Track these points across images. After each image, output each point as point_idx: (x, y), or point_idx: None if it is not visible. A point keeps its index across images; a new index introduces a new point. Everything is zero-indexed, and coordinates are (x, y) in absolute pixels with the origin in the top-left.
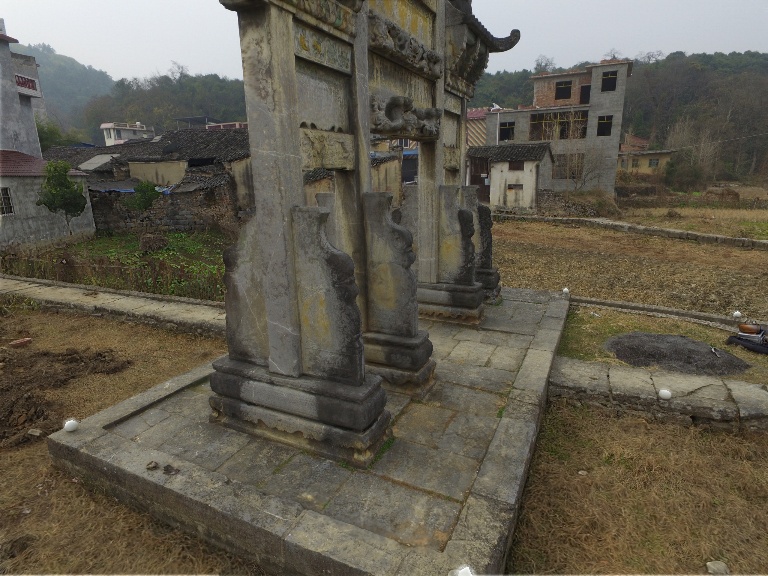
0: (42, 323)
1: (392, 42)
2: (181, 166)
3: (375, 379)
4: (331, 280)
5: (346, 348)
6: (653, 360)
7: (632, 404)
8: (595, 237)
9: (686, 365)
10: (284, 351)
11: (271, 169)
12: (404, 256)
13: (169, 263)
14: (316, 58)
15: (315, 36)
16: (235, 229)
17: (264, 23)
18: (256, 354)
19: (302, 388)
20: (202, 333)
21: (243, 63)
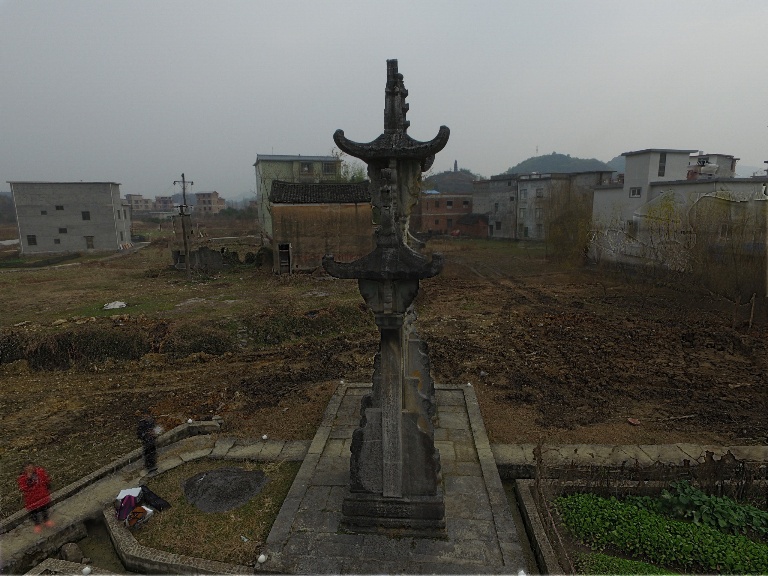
0: (689, 440)
1: None
2: None
3: None
4: None
5: None
6: None
7: None
8: None
9: None
10: None
11: None
12: None
13: None
14: None
15: None
16: None
17: None
18: None
19: None
20: None
21: None
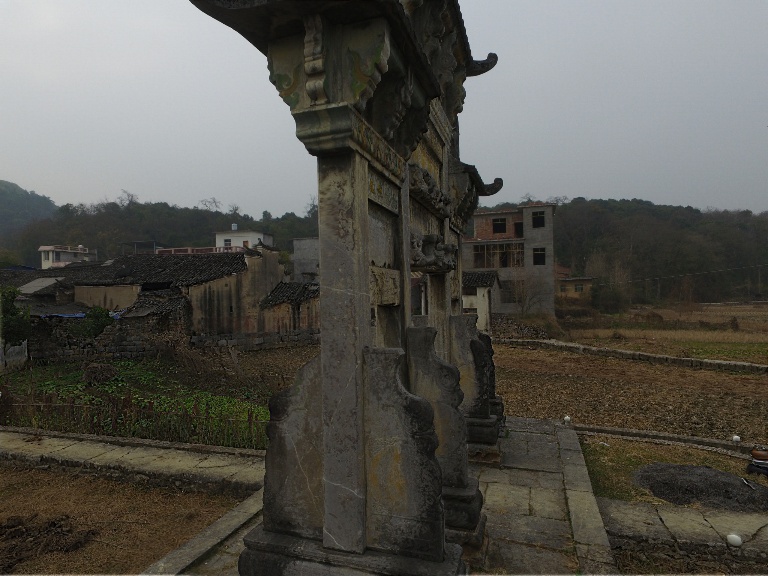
0: None
1: (426, 187)
2: (134, 290)
3: (455, 549)
4: (410, 430)
5: (427, 513)
6: (692, 496)
7: (701, 554)
8: (555, 359)
9: (727, 501)
10: (346, 519)
11: (345, 308)
12: (454, 395)
13: (119, 396)
14: (379, 200)
15: (378, 180)
16: (195, 356)
17: (349, 168)
18: (303, 523)
19: (371, 568)
20: (181, 486)
21: (321, 203)
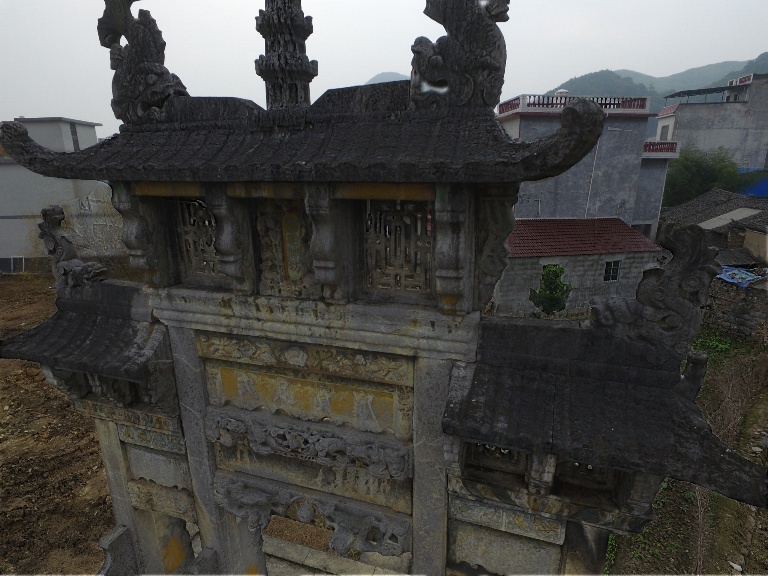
0: None
1: (227, 441)
2: None
3: None
4: None
5: None
6: None
7: None
8: None
9: None
10: None
11: None
12: None
13: None
14: (142, 443)
15: (140, 429)
16: None
17: None
18: None
19: None
20: None
21: None
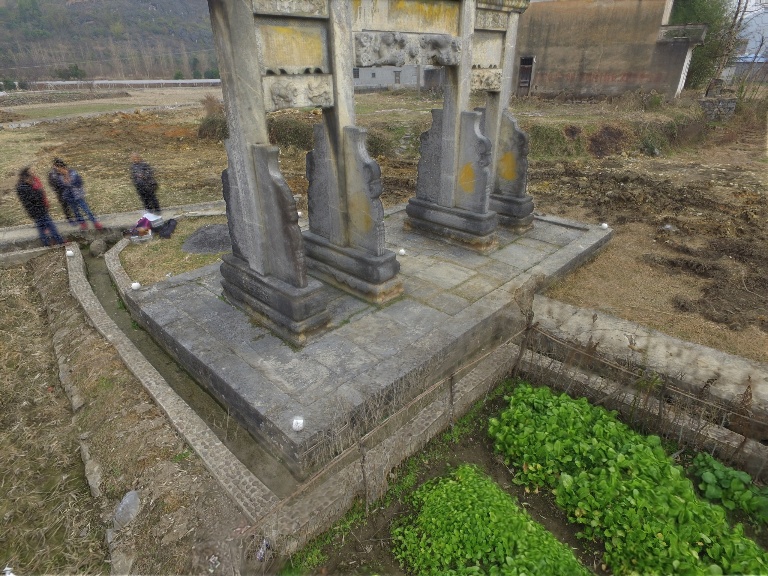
0: None
1: None
2: None
3: None
4: None
5: None
6: None
7: None
8: None
9: None
10: None
11: None
12: None
13: None
14: None
15: None
16: None
17: None
18: None
19: None
20: None
21: None
